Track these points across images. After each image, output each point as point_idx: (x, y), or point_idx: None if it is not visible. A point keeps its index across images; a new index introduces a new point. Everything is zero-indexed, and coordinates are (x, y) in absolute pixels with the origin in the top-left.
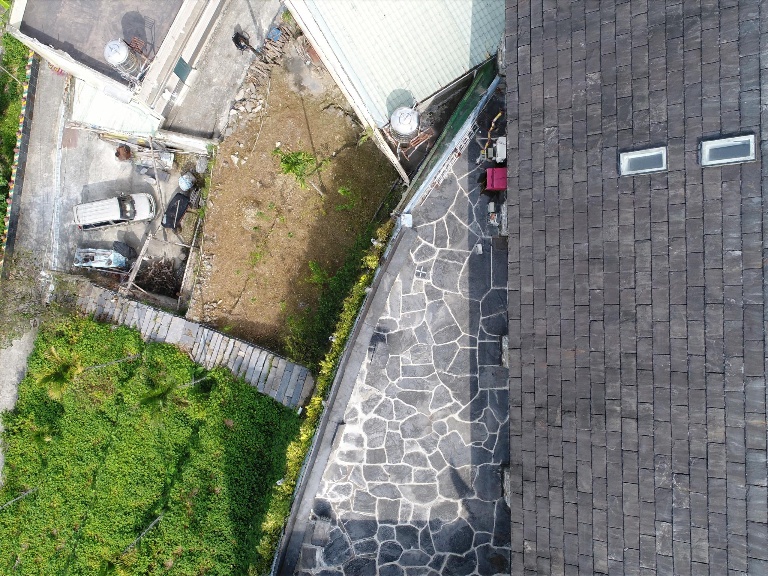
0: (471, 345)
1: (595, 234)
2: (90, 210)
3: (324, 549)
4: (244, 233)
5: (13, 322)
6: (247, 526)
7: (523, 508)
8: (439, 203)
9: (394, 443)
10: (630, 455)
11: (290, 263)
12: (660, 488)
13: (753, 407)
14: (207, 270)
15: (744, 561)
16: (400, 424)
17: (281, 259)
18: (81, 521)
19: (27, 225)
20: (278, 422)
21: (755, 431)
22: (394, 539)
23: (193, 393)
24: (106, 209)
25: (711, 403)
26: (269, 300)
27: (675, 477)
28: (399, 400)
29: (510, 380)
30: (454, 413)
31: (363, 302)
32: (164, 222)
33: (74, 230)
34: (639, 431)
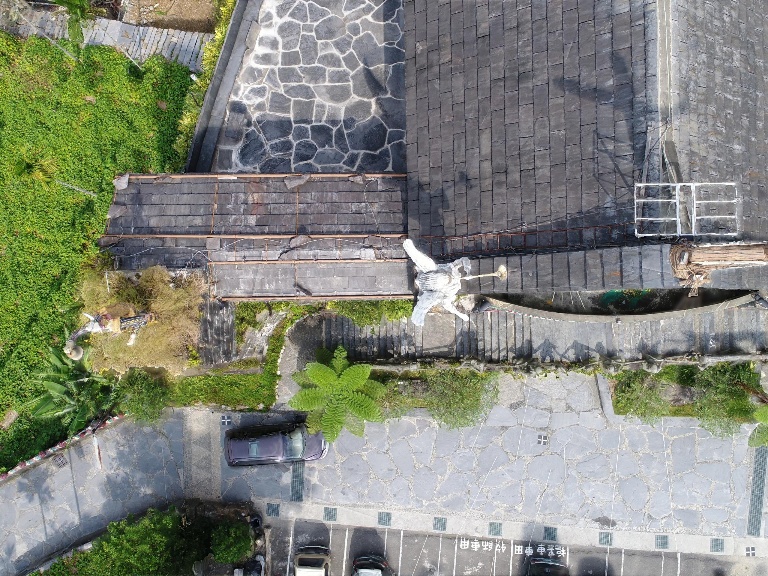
0: None
1: None
2: None
3: (240, 150)
4: None
5: None
6: None
7: (415, 12)
8: None
9: (308, 45)
10: None
11: None
12: None
13: None
14: None
15: None
16: (314, 26)
17: None
18: None
19: None
20: None
21: None
22: (309, 138)
23: (126, 75)
24: None
25: None
26: None
27: None
28: (313, 3)
29: None
30: (367, 14)
31: None
32: None
33: None
34: None
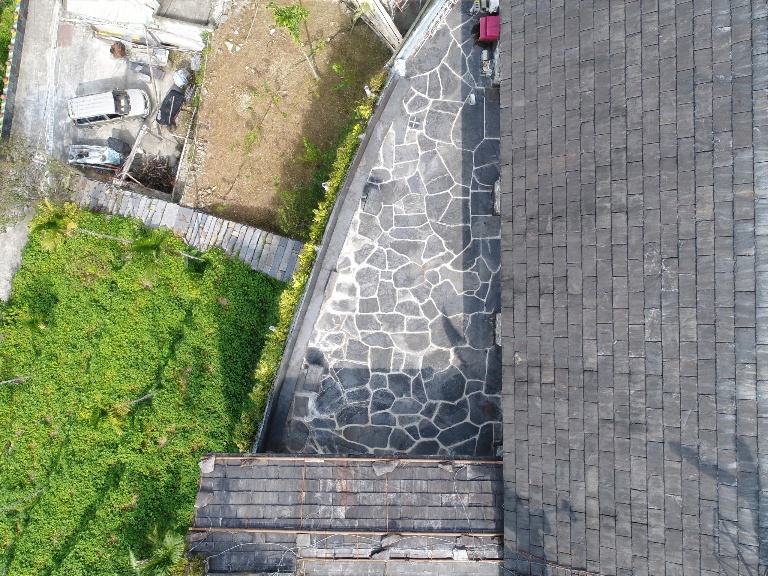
0: (464, 195)
1: (586, 36)
2: (84, 103)
3: (316, 397)
4: (238, 120)
5: (7, 204)
6: (240, 403)
7: (514, 321)
8: (432, 54)
9: (387, 292)
10: (620, 248)
11: (284, 147)
12: (649, 275)
13: (741, 178)
14: (201, 157)
15: (732, 332)
16: (393, 273)
17: (275, 144)
18: (75, 408)
19: (21, 123)
20: (272, 300)
21: (743, 201)
22: (386, 387)
23: (187, 271)
24: (101, 103)
25: (700, 182)
26: (263, 184)
27: (664, 262)
28: (392, 250)
29: (501, 196)
30: (446, 262)
31: (356, 150)
32: (159, 118)
33: (68, 128)
34: (629, 223)
